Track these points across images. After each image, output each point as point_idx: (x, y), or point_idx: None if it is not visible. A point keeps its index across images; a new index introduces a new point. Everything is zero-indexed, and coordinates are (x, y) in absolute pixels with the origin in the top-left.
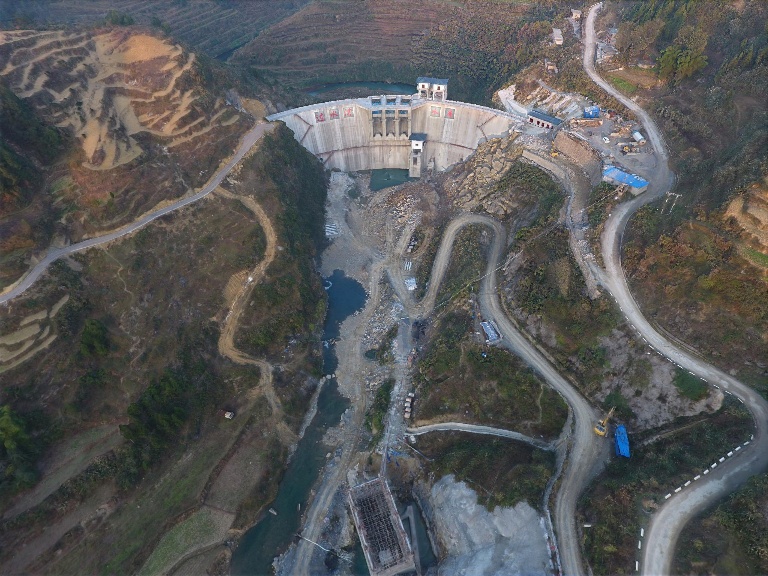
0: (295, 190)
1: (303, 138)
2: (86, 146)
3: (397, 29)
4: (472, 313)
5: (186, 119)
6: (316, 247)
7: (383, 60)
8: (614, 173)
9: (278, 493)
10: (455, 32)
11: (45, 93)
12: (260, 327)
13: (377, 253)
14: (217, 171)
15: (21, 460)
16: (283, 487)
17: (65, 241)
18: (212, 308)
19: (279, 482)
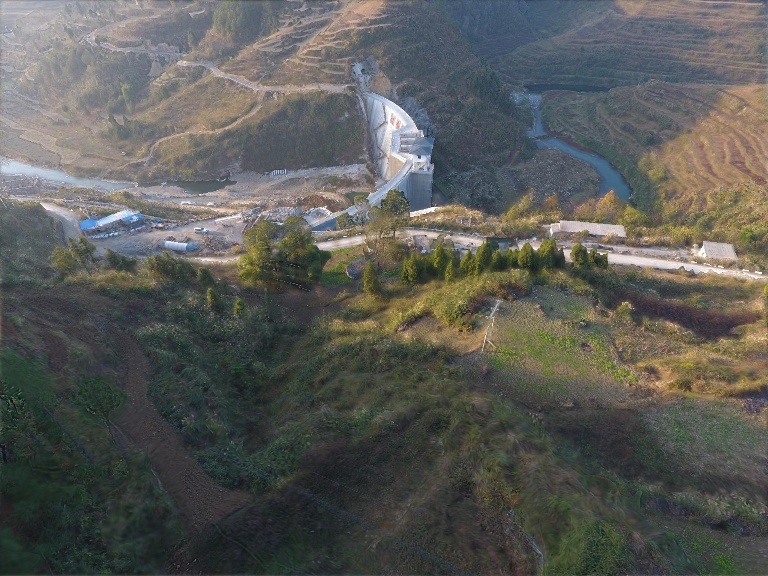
0: (287, 130)
1: (379, 127)
2: (272, 35)
3: (765, 162)
4: (91, 193)
5: (311, 52)
6: (253, 165)
7: (671, 175)
8: (120, 215)
9: (75, 176)
10: (760, 202)
11: (298, 4)
12: (168, 146)
13: (243, 194)
14: (282, 87)
15: (115, 103)
16: (78, 178)
17: (218, 64)
18: (181, 125)
19: (81, 176)
